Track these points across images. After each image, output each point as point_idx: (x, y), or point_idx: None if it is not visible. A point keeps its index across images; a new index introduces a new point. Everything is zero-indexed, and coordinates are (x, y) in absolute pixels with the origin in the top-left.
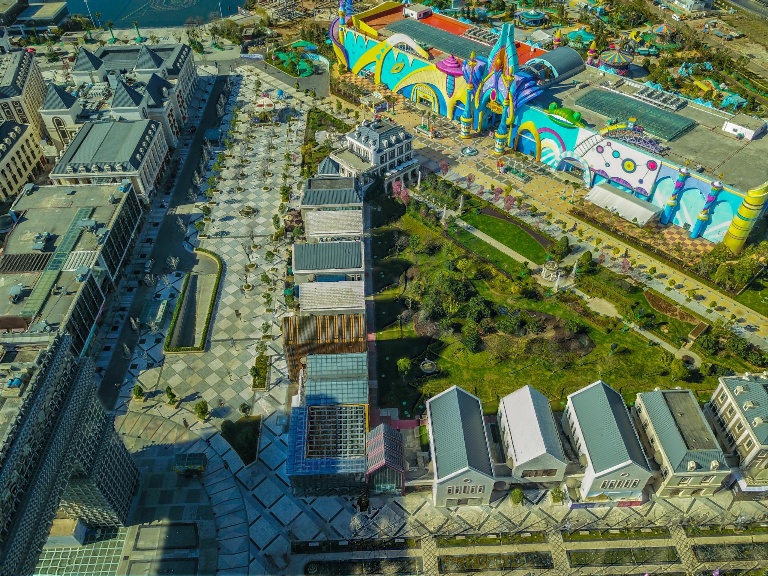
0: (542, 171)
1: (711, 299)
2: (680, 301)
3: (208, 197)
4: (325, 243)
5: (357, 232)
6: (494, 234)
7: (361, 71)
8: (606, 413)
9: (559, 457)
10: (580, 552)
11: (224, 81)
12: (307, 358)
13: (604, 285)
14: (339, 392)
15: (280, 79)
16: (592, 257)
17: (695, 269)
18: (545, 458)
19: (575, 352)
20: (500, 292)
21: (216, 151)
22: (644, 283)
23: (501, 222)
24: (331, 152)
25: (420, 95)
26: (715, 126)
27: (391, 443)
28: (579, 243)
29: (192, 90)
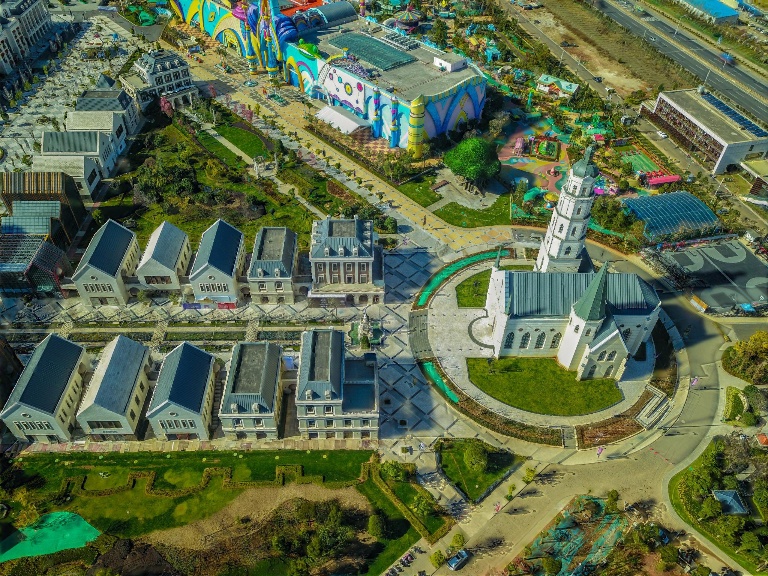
0: (301, 99)
1: (377, 187)
2: (352, 188)
3: (17, 110)
4: (69, 132)
5: (108, 129)
6: (234, 140)
7: (192, 21)
8: (212, 238)
9: (167, 265)
10: (175, 333)
11: (75, 27)
12: (13, 203)
13: (299, 176)
14: (27, 224)
15: (124, 27)
16: (302, 158)
17: (376, 167)
18: (153, 264)
19: (247, 217)
20: (213, 177)
21: (40, 77)
22: (332, 175)
23: (245, 132)
24: (120, 75)
25: (228, 40)
26: (430, 62)
27: (46, 253)
28: (298, 148)
29: (42, 32)
